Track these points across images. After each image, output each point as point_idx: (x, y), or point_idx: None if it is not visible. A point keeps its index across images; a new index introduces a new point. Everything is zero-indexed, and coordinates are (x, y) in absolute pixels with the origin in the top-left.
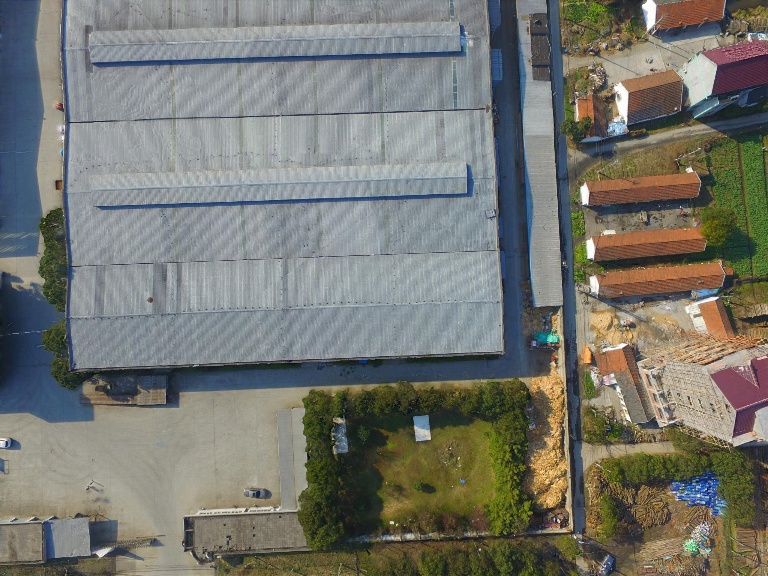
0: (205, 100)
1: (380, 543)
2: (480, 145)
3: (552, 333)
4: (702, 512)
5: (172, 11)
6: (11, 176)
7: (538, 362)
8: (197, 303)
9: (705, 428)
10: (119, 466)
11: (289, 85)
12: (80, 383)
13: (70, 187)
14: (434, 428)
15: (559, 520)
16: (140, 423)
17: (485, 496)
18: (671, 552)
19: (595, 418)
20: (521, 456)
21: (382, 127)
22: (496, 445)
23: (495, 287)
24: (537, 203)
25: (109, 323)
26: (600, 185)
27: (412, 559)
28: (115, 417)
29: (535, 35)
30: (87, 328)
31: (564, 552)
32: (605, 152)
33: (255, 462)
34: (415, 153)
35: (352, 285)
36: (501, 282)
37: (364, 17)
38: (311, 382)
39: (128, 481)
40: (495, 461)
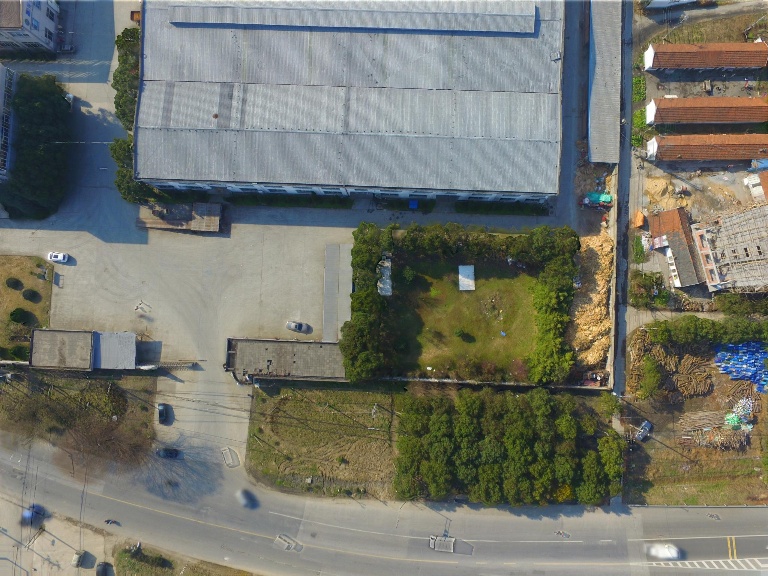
0: None
1: (417, 384)
2: None
3: (605, 194)
4: (746, 386)
5: None
6: (89, 6)
7: (588, 222)
8: (260, 122)
9: (761, 280)
10: (168, 290)
11: None
12: (140, 198)
13: (148, 3)
14: (479, 279)
15: (599, 377)
16: (191, 250)
17: (525, 350)
18: (711, 423)
19: (643, 279)
20: (566, 306)
21: None
22: (542, 293)
23: (554, 128)
24: (600, 60)
25: (174, 135)
26: (665, 47)
27: (449, 398)
28: (168, 242)
29: None
30: (153, 138)
31: (601, 414)
32: (672, 19)
33: (299, 297)
34: None
35: (412, 116)
36: (561, 123)
37: None
38: None
39: (175, 305)
40: (539, 311)
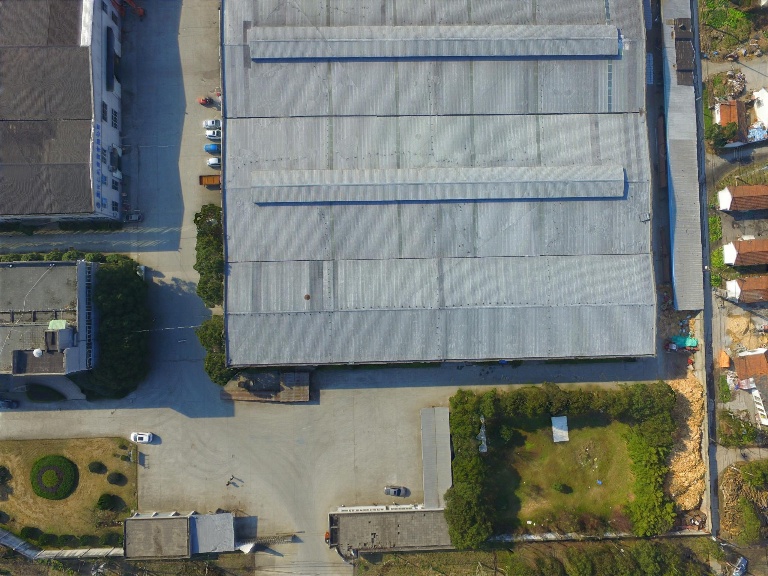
0: (362, 98)
1: (520, 542)
2: (634, 149)
3: (690, 337)
4: None
5: (330, 8)
6: (153, 170)
7: (675, 365)
8: (354, 301)
9: None
10: (259, 462)
11: (446, 85)
12: None
13: (228, 183)
14: (572, 429)
15: (697, 522)
16: (281, 420)
17: (621, 497)
18: None
19: (733, 421)
20: (664, 458)
21: (537, 129)
22: (640, 447)
23: (648, 290)
24: (680, 207)
25: (266, 320)
26: (742, 190)
27: (556, 559)
28: (256, 413)
29: (679, 40)
30: (244, 324)
31: (698, 554)
32: (743, 158)
33: (394, 460)
34: (570, 155)
35: (507, 286)
36: (655, 285)
37: (521, 18)
38: (451, 381)
39: (268, 477)
40: (636, 463)
